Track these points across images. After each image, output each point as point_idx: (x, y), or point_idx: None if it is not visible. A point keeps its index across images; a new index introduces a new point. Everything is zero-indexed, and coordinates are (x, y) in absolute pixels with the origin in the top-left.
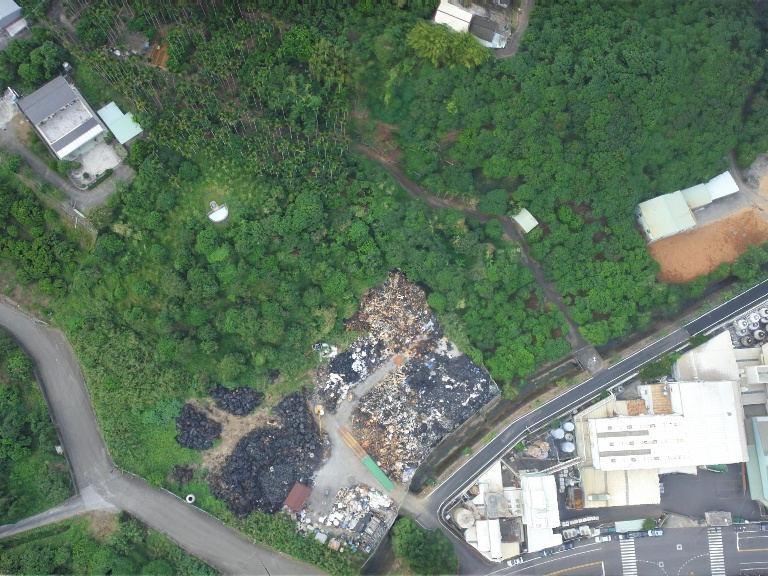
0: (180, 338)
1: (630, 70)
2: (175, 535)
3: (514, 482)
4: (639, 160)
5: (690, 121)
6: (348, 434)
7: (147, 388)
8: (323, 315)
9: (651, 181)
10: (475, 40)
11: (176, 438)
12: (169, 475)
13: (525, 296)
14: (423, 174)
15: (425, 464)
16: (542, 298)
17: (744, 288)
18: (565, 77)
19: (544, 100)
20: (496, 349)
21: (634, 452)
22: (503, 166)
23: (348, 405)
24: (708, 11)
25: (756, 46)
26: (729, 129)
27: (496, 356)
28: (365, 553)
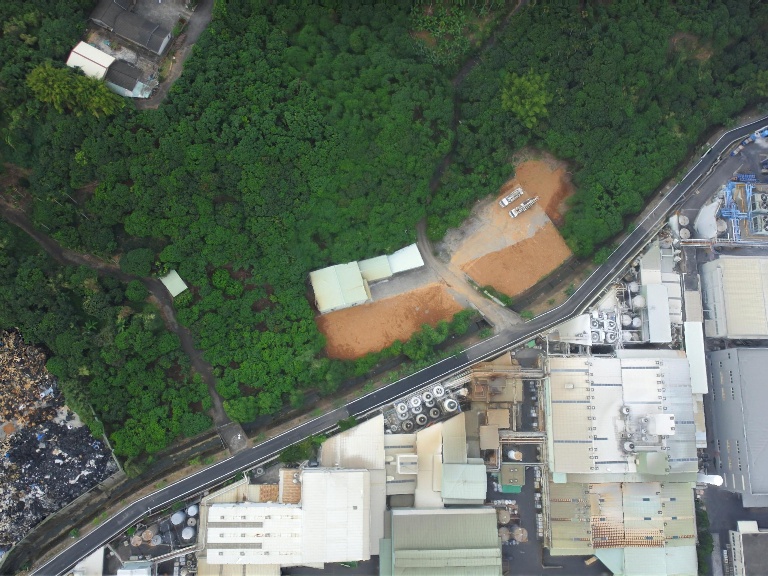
0: None
1: (291, 133)
2: None
3: None
4: (306, 227)
5: (367, 190)
6: None
7: None
8: None
9: (321, 250)
10: (109, 87)
11: None
12: None
13: (164, 365)
14: (53, 226)
15: (29, 544)
16: (186, 368)
17: (411, 369)
18: (211, 135)
19: (186, 158)
20: (125, 421)
21: (244, 545)
22: (143, 224)
23: None
24: (392, 77)
25: (444, 117)
26: (412, 201)
27: (123, 429)
28: None
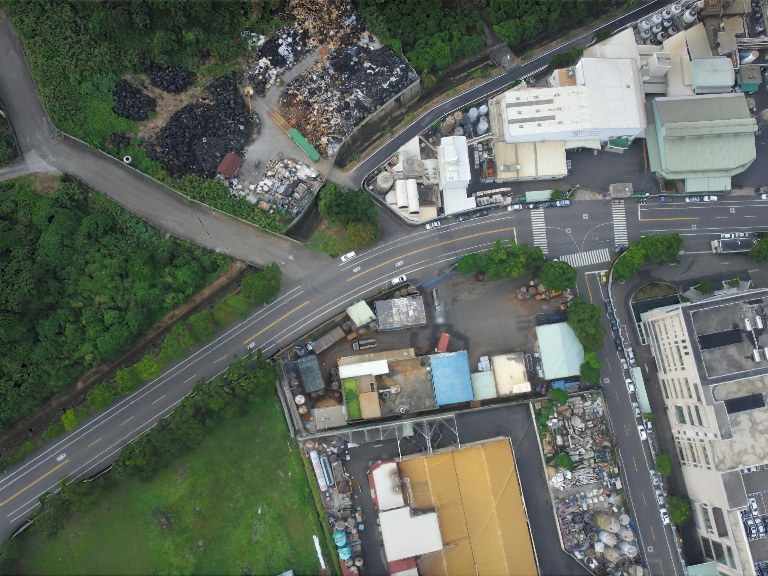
0: (113, 7)
1: None
2: (114, 195)
3: (432, 156)
4: None
5: None
6: (276, 114)
7: (84, 58)
8: (250, 1)
9: None
10: None
11: (113, 109)
12: (107, 141)
13: None
14: None
15: (350, 147)
16: None
17: None
18: None
19: None
20: (415, 43)
21: (540, 118)
22: None
23: (276, 90)
24: None
25: None
26: None
27: (415, 49)
28: (293, 216)
